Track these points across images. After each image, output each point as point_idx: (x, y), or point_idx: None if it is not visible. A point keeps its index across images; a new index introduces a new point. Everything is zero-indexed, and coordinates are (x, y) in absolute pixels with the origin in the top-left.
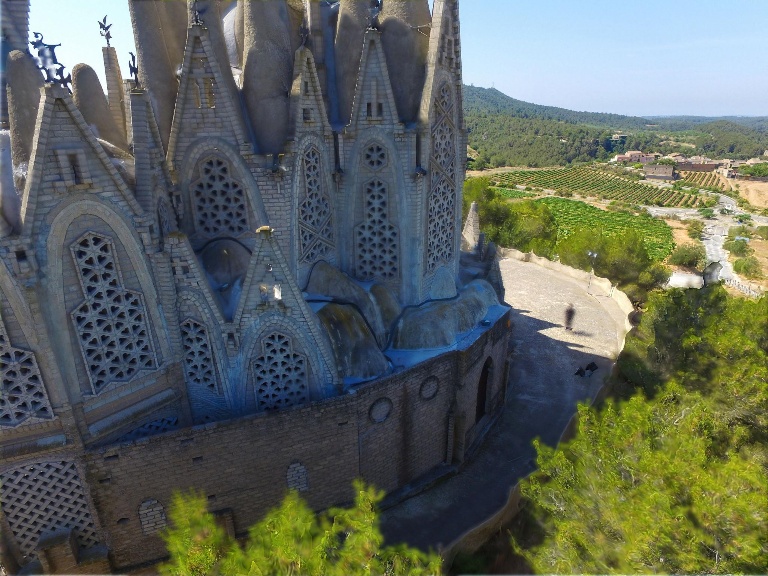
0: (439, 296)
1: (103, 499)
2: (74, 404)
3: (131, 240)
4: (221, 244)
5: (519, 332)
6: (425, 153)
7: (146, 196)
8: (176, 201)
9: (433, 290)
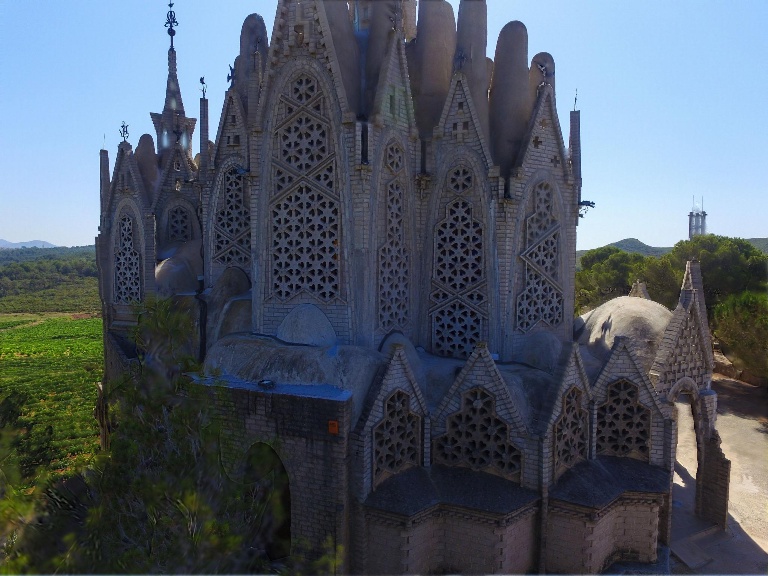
0: (280, 335)
1: None
2: (110, 303)
3: (141, 222)
4: None
5: None
6: (264, 154)
7: None
8: (201, 212)
9: None
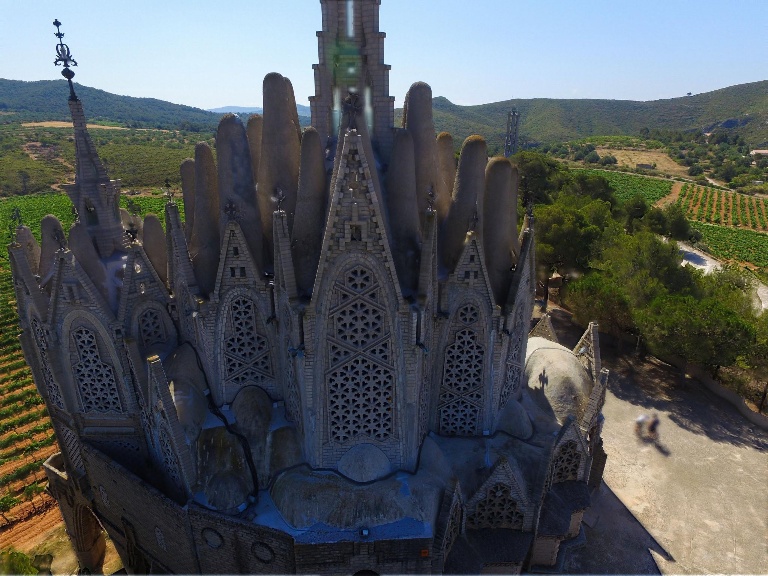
0: (345, 472)
1: (87, 470)
2: (75, 413)
3: (107, 335)
4: (181, 348)
5: (599, 574)
6: (318, 332)
7: (120, 311)
8: (173, 309)
9: (341, 462)
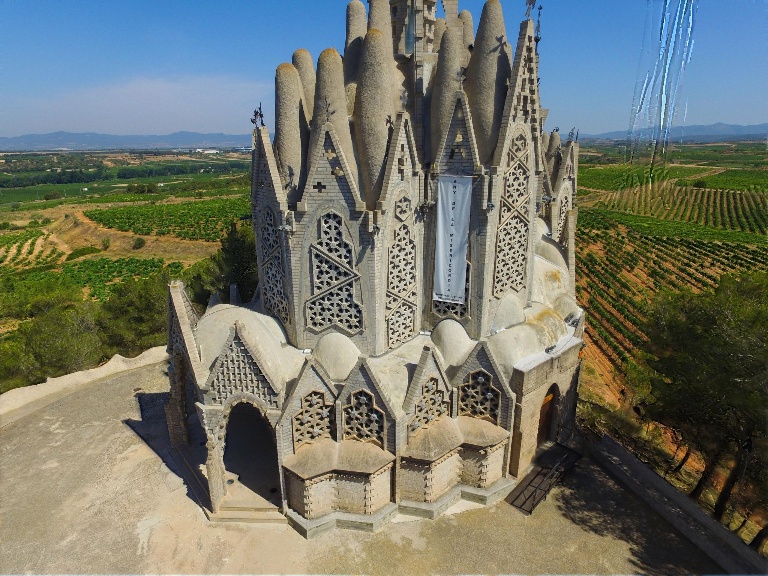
0: None
1: None
2: None
3: None
4: None
5: None
6: None
7: None
8: None
9: None
